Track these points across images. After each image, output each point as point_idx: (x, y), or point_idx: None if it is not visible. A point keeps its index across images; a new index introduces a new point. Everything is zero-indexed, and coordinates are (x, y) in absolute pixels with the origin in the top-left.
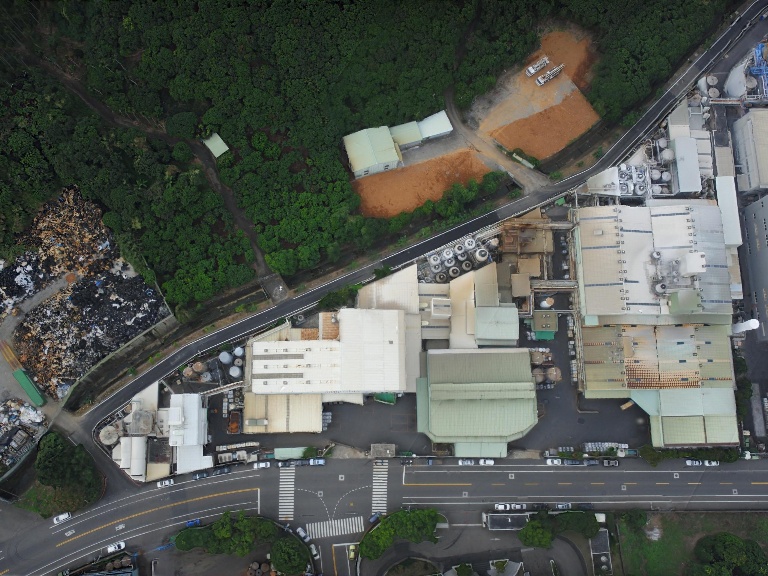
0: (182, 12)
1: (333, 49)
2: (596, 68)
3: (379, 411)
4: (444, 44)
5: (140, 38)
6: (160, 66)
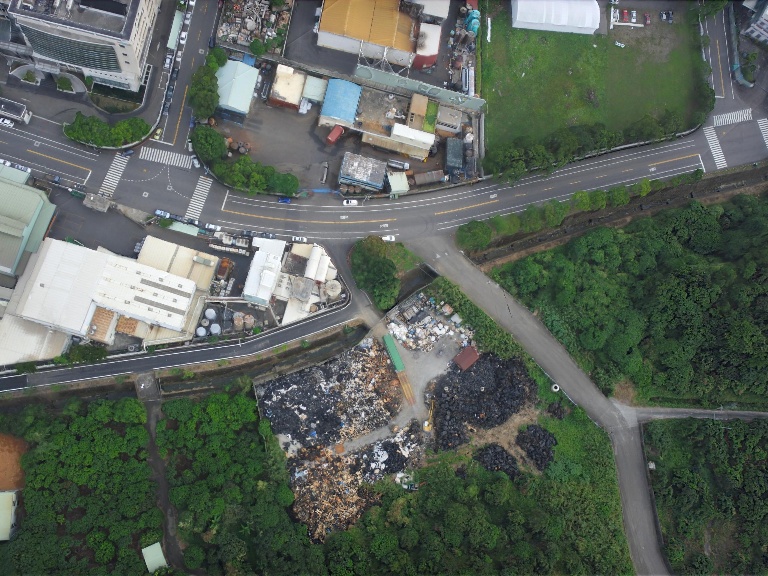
0: None
1: None
2: None
3: (88, 240)
4: None
5: None
6: None
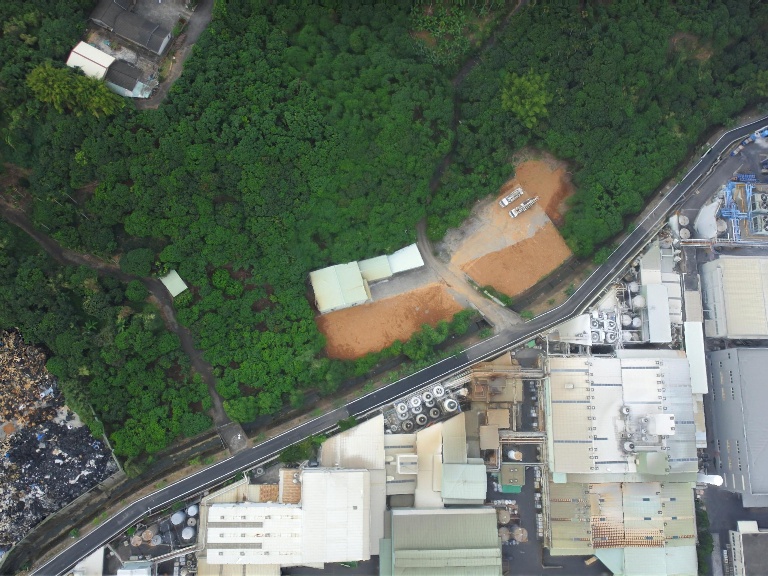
0: (141, 148)
1: (303, 186)
2: (570, 202)
3: (340, 571)
4: (418, 178)
5: (94, 172)
6: (115, 202)
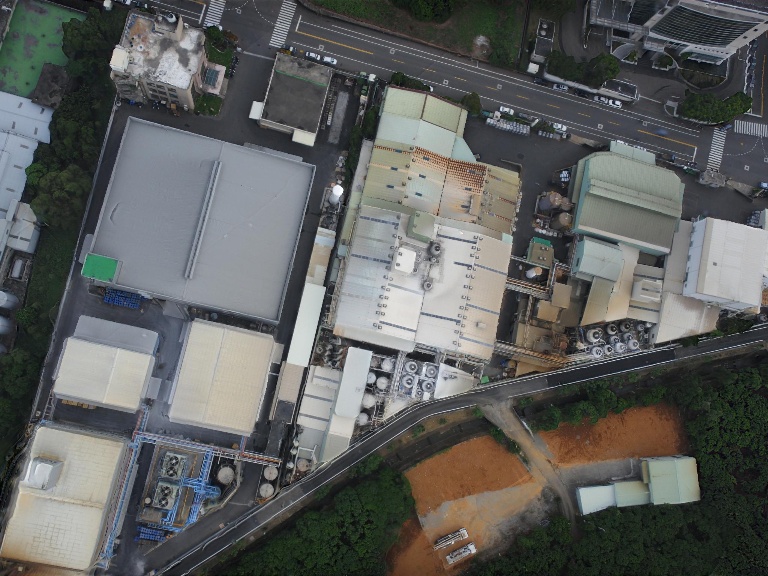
0: None
1: None
2: None
3: (706, 216)
4: None
5: None
6: None
